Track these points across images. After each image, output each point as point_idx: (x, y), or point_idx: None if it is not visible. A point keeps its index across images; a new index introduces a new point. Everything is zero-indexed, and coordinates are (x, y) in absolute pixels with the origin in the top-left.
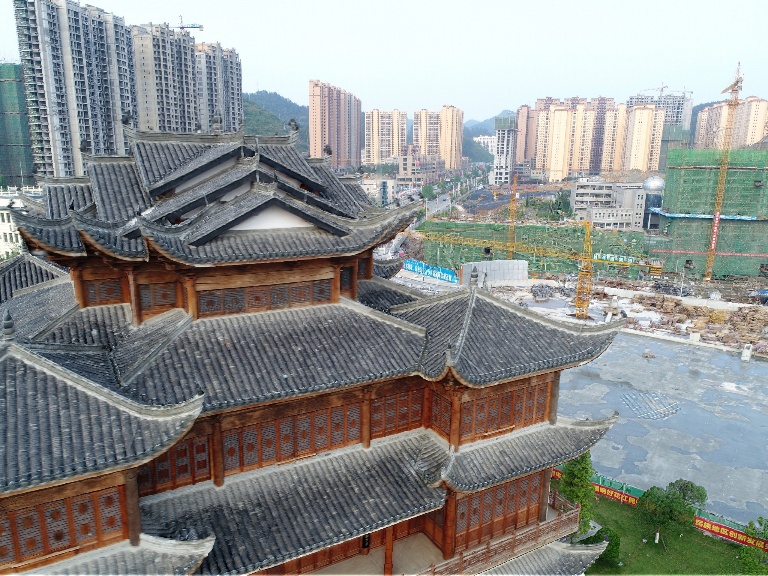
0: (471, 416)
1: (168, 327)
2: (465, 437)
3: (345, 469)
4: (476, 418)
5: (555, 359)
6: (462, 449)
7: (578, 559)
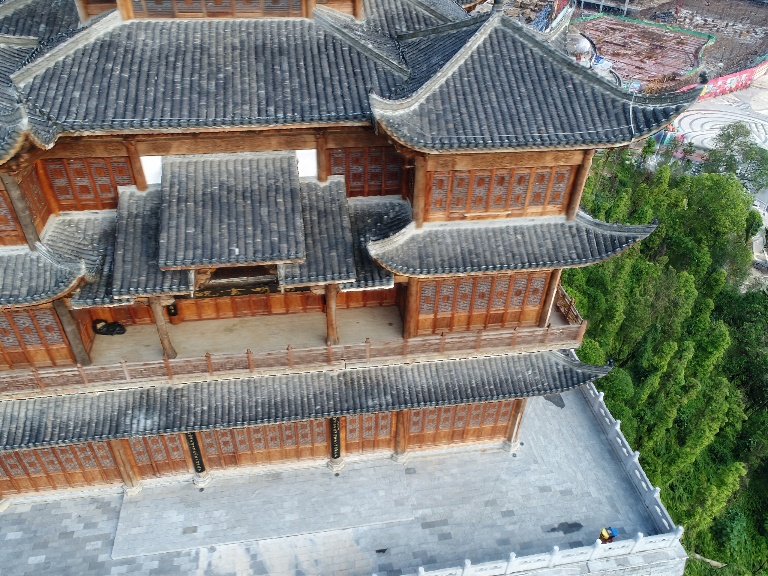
0: None
1: (393, 7)
2: None
3: None
4: None
5: None
6: None
7: None
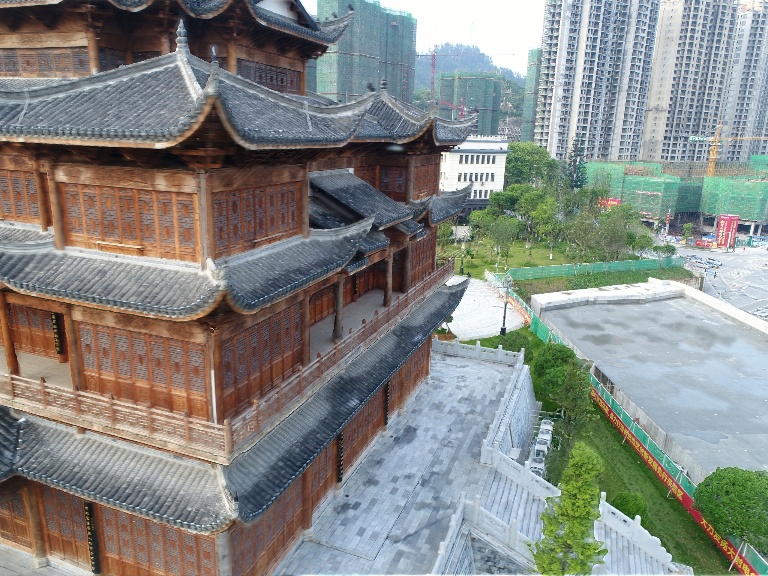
0: (79, 208)
1: None
2: (77, 237)
3: (2, 238)
4: (86, 214)
5: (121, 129)
6: (71, 251)
7: (218, 510)
